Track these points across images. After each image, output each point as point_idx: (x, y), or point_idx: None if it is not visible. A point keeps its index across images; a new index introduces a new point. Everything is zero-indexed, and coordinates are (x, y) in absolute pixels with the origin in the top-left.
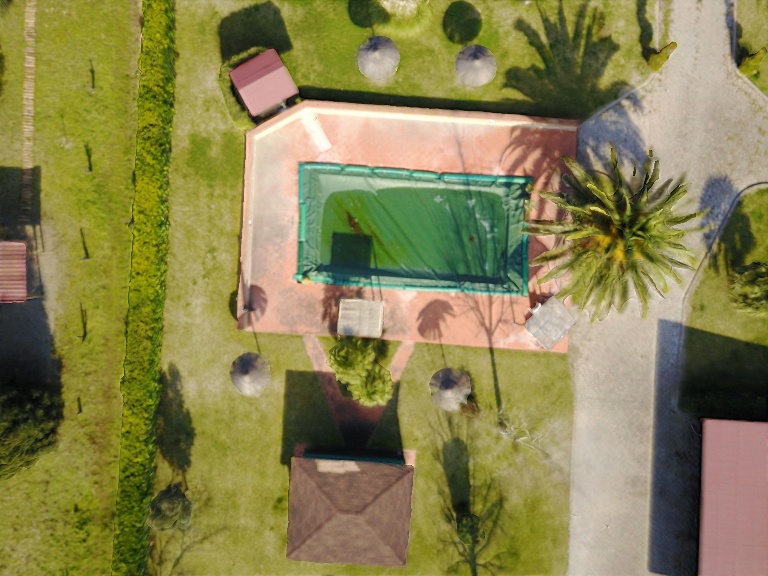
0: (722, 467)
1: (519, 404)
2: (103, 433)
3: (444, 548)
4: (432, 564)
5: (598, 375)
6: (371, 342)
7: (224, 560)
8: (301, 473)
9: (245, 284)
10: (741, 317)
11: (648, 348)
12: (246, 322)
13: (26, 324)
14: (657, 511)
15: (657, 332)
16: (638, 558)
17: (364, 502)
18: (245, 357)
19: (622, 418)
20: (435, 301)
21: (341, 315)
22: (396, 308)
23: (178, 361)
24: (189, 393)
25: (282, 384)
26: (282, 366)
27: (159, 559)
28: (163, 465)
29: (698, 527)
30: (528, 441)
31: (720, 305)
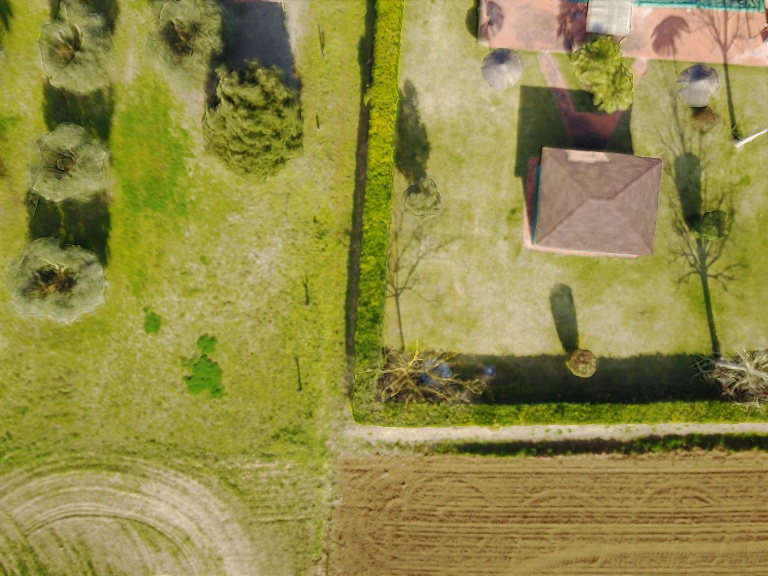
0: None
1: (753, 120)
2: (338, 152)
3: (676, 260)
4: (663, 275)
5: None
6: (617, 42)
7: (459, 268)
8: (552, 162)
9: None
10: None
11: None
12: None
13: (269, 42)
14: None
15: None
16: None
17: (615, 190)
18: (497, 52)
19: None
20: (670, 18)
21: (590, 13)
22: None
23: (414, 78)
24: (425, 109)
25: (516, 99)
26: None
27: (396, 266)
28: (399, 178)
29: None
30: None
31: None
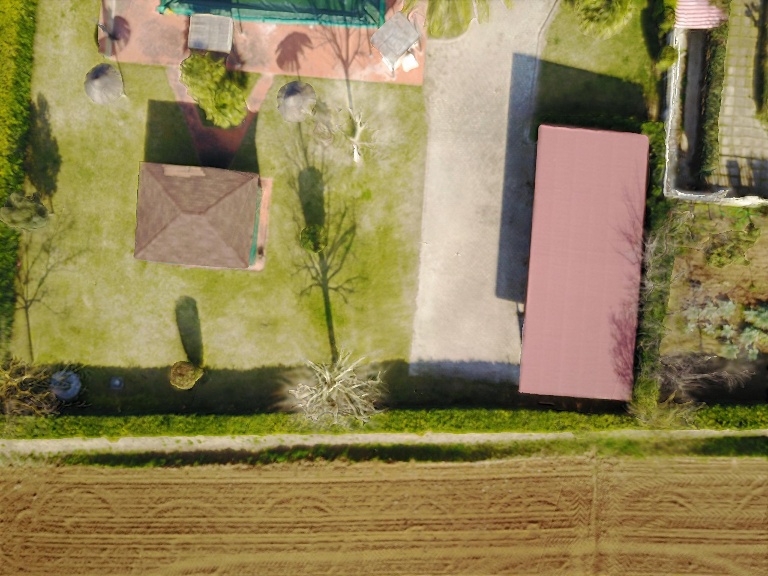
0: (557, 173)
1: None
2: None
3: (298, 272)
4: (286, 287)
5: (453, 109)
6: (221, 58)
7: (87, 280)
8: (148, 176)
9: (106, 9)
10: (595, 50)
11: (503, 82)
12: (109, 51)
13: None
14: (507, 240)
15: (512, 66)
16: (487, 285)
17: (208, 204)
18: (98, 67)
19: (475, 150)
20: (293, 34)
21: (191, 29)
22: (255, 41)
23: (46, 91)
24: (56, 122)
25: (144, 113)
26: (145, 96)
27: (26, 279)
28: (31, 191)
29: (531, 230)
30: (362, 138)
31: (574, 38)
